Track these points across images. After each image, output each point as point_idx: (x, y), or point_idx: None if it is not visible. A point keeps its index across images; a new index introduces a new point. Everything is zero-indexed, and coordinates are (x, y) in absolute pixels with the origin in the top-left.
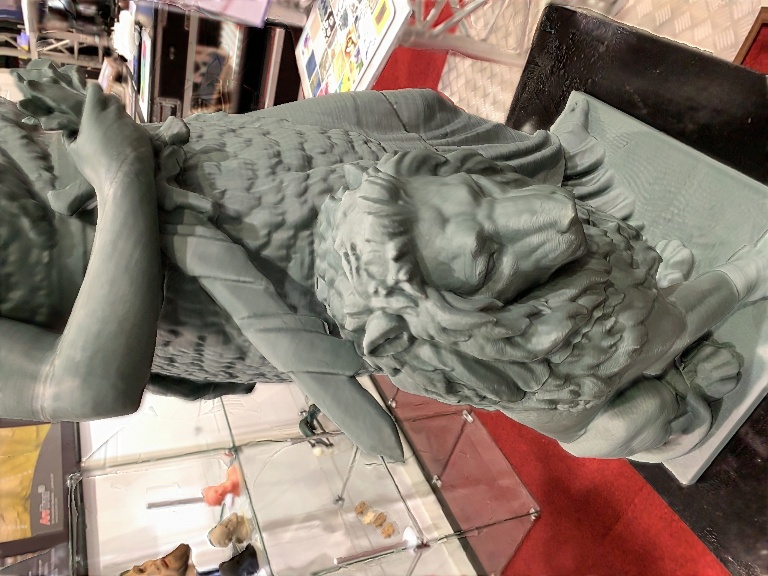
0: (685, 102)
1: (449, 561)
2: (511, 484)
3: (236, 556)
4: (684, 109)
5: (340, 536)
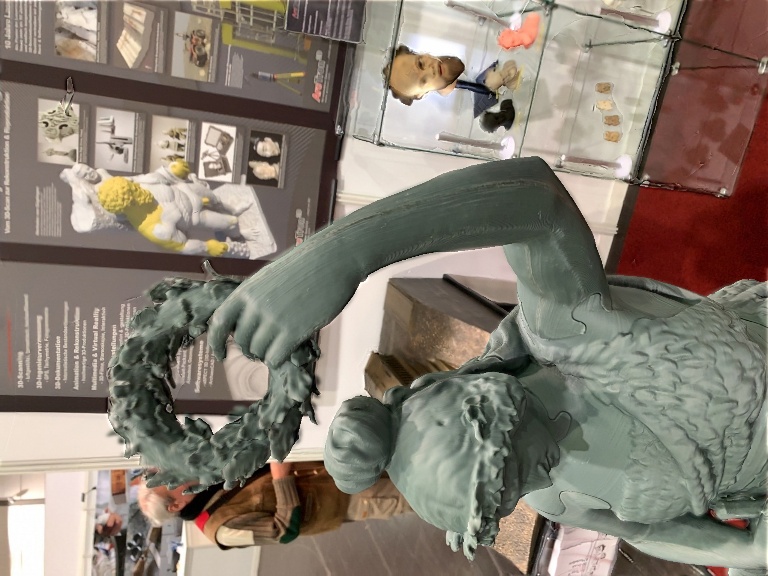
0: None
1: (625, 137)
2: (727, 95)
3: (500, 118)
4: None
5: (565, 70)
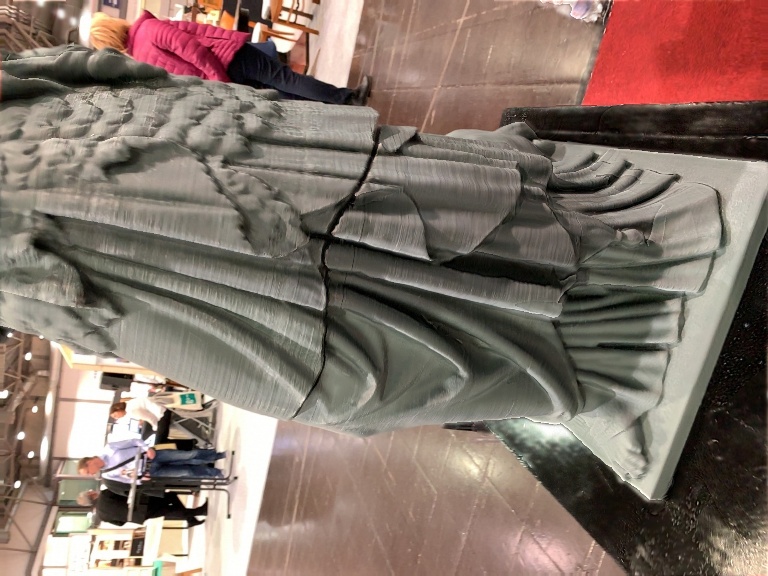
0: (561, 452)
1: None
2: None
3: None
4: (561, 445)
5: None
